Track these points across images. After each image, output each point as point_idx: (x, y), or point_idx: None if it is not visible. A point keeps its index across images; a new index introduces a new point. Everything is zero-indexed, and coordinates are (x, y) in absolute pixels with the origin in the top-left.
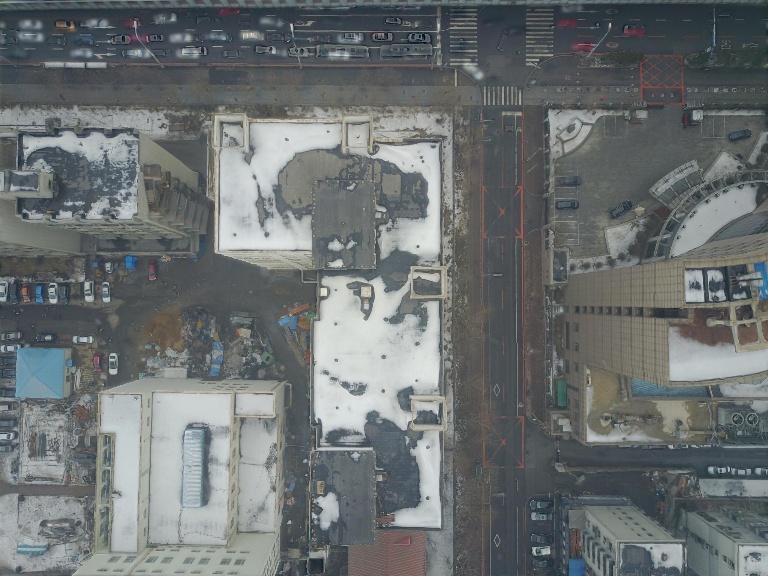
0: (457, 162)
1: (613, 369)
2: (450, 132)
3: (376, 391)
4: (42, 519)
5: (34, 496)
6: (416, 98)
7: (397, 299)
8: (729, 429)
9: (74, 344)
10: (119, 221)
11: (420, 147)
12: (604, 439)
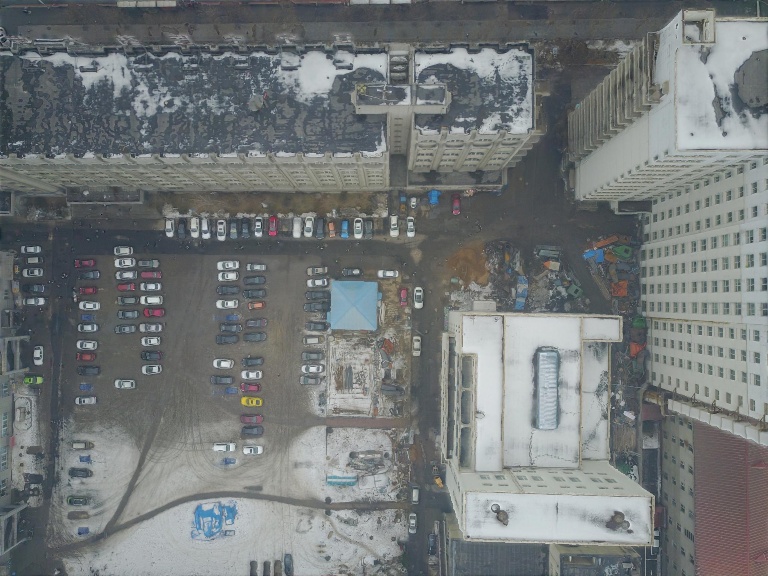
0: None
1: None
2: None
3: None
4: (350, 451)
5: (342, 428)
6: None
7: None
8: None
9: (378, 278)
10: (514, 136)
11: None
12: None
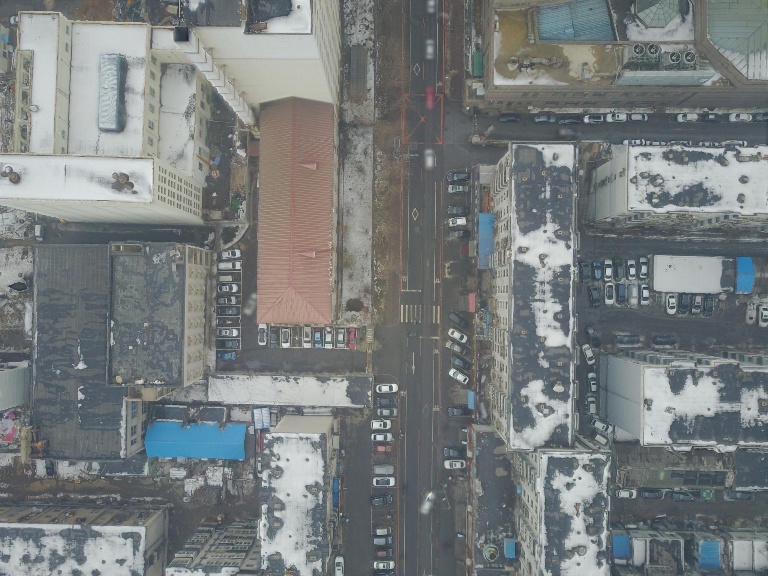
0: None
1: None
2: None
3: None
4: None
5: None
6: None
7: None
8: (631, 61)
9: (12, 25)
10: None
11: None
12: (511, 83)
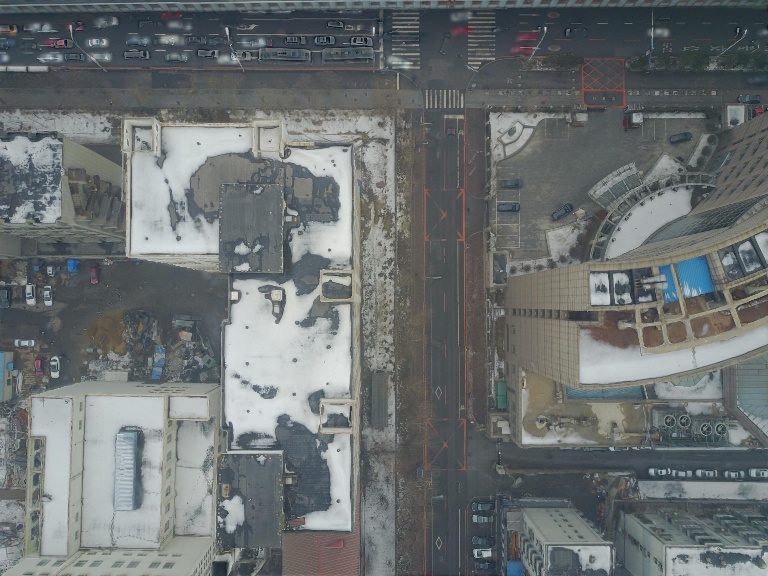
0: (399, 165)
1: (539, 372)
2: (392, 135)
3: (287, 394)
4: None
5: None
6: (358, 101)
7: (308, 302)
8: (662, 431)
9: (16, 347)
10: (43, 225)
11: (332, 151)
12: (539, 441)
